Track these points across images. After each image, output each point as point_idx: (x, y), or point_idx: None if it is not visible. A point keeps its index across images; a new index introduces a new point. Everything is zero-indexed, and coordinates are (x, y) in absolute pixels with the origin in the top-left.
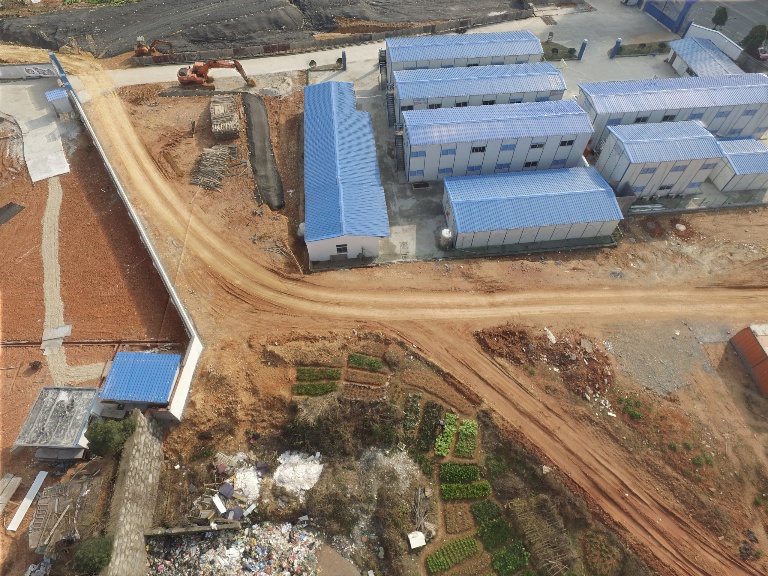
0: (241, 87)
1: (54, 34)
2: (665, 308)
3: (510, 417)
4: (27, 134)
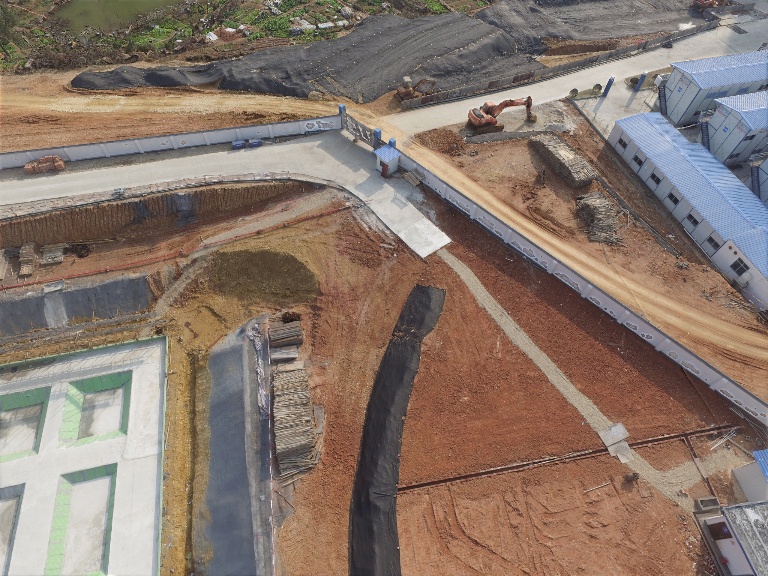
0: (523, 124)
1: (289, 78)
2: None
3: None
4: (371, 201)
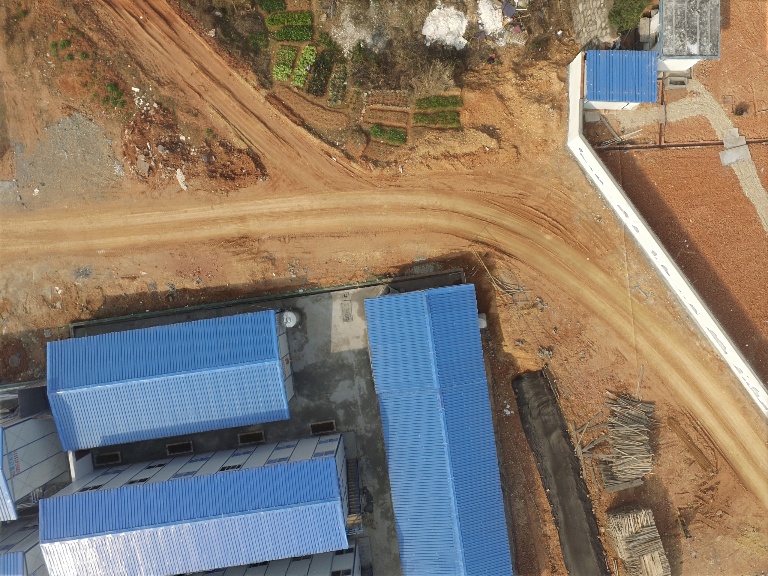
0: None
1: None
2: (39, 226)
3: (239, 84)
4: None
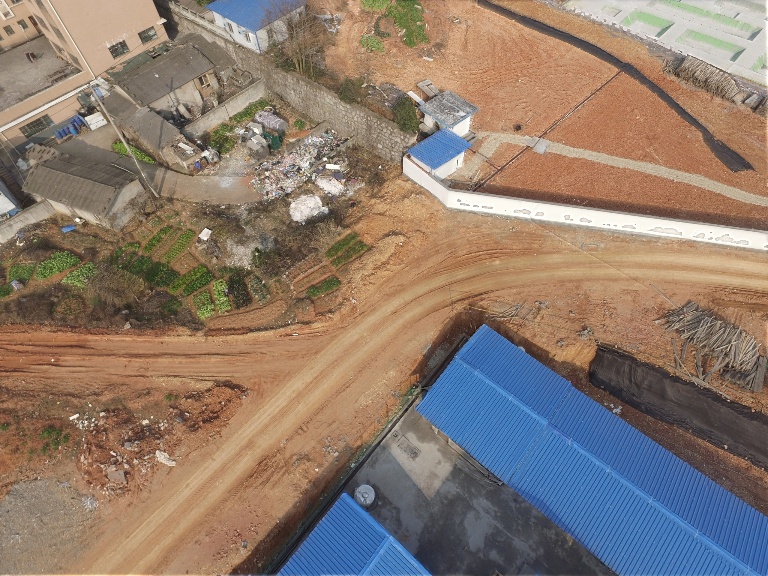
0: None
1: None
2: None
3: (174, 344)
4: None
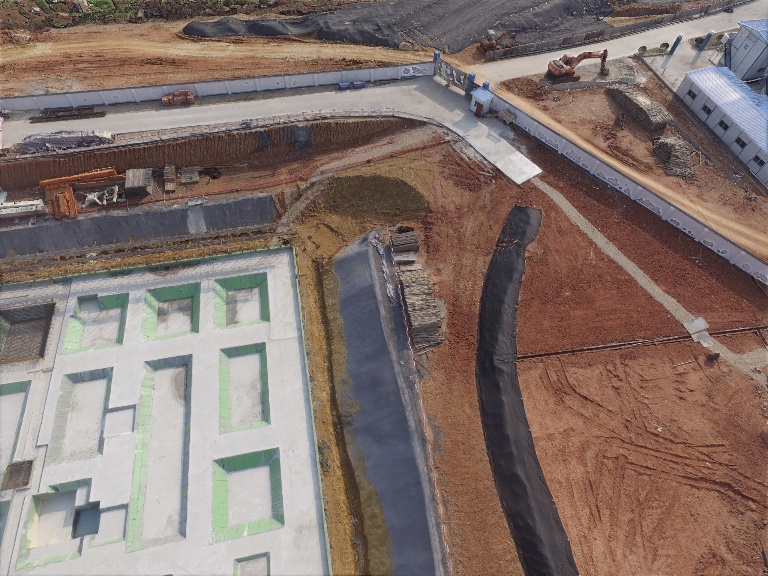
0: (596, 76)
1: (380, 30)
2: None
3: None
4: (468, 136)
